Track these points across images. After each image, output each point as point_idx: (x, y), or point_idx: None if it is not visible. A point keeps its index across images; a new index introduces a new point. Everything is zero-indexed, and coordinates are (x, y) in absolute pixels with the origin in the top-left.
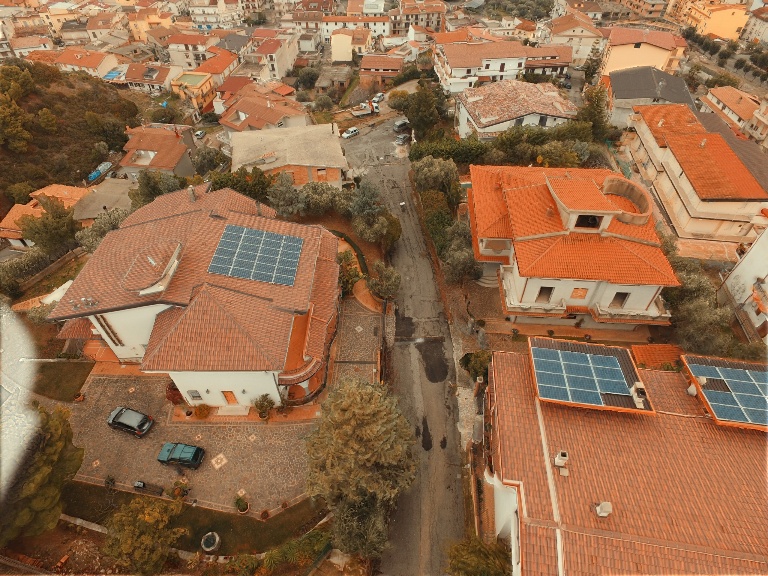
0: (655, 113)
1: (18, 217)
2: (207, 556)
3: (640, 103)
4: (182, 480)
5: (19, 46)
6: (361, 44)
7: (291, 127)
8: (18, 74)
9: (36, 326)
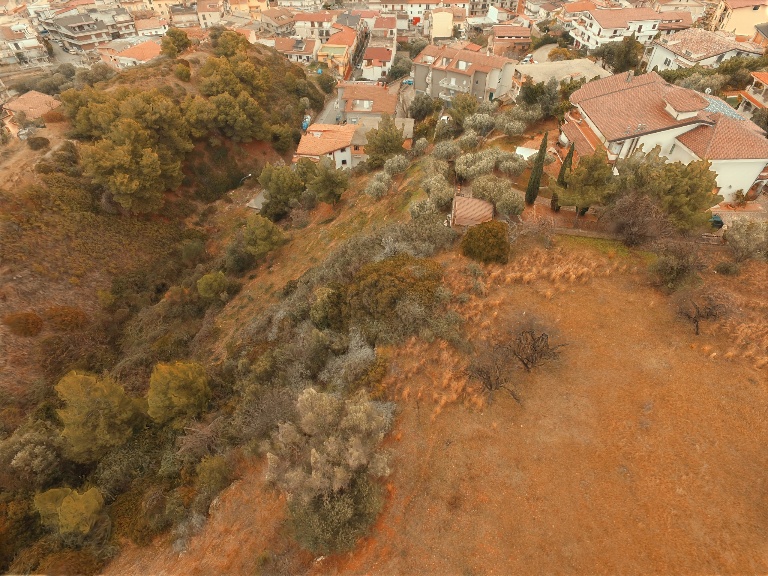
0: None
1: (310, 145)
2: None
3: None
4: None
5: (142, 27)
6: (461, 21)
7: None
8: (237, 38)
9: None
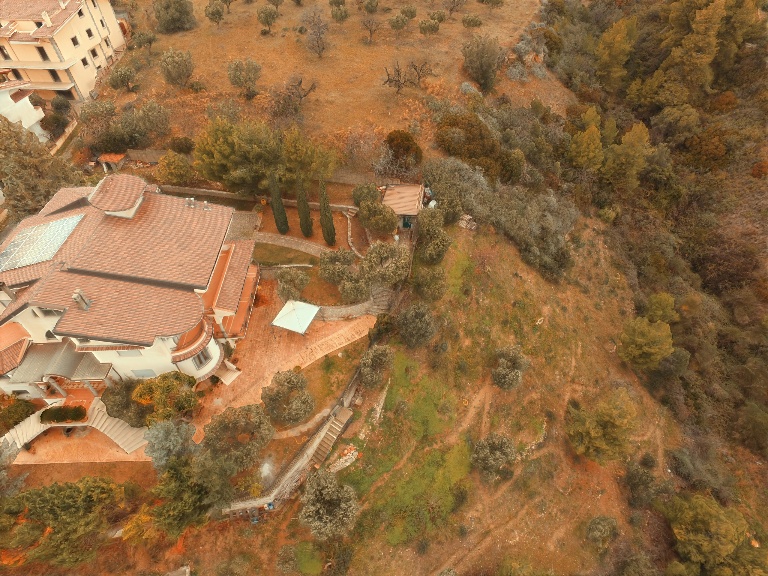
0: None
1: None
2: None
3: None
4: None
5: None
6: None
7: None
8: None
9: None
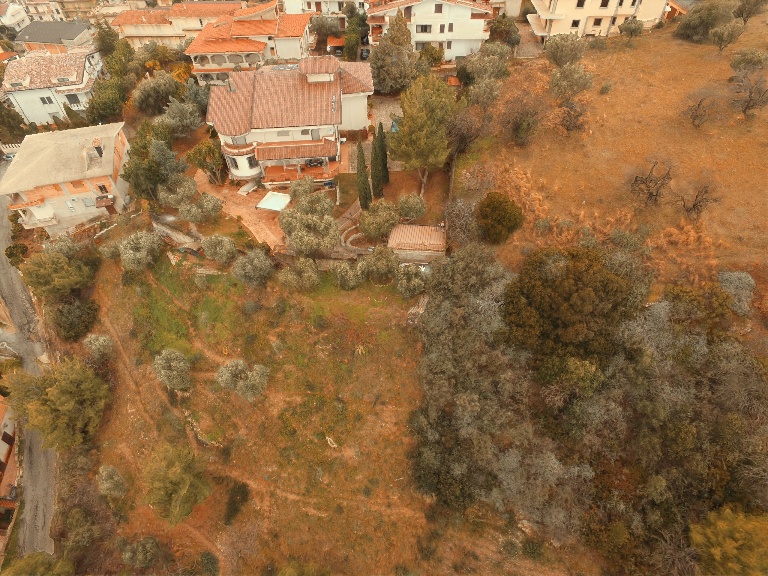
0: (127, 20)
1: None
2: None
3: (86, 35)
4: None
5: None
6: None
7: (15, 157)
8: None
9: (312, 196)
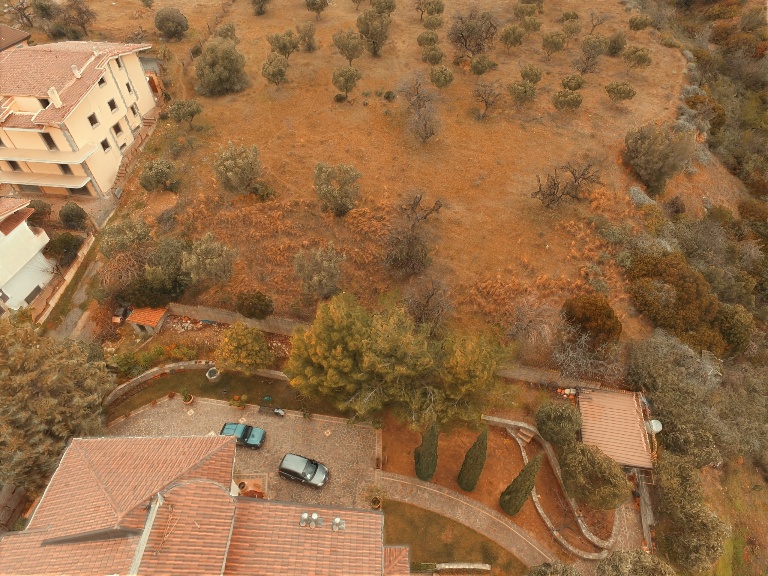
0: None
1: None
2: (214, 363)
3: None
4: (244, 421)
5: None
6: None
7: None
8: None
9: None
